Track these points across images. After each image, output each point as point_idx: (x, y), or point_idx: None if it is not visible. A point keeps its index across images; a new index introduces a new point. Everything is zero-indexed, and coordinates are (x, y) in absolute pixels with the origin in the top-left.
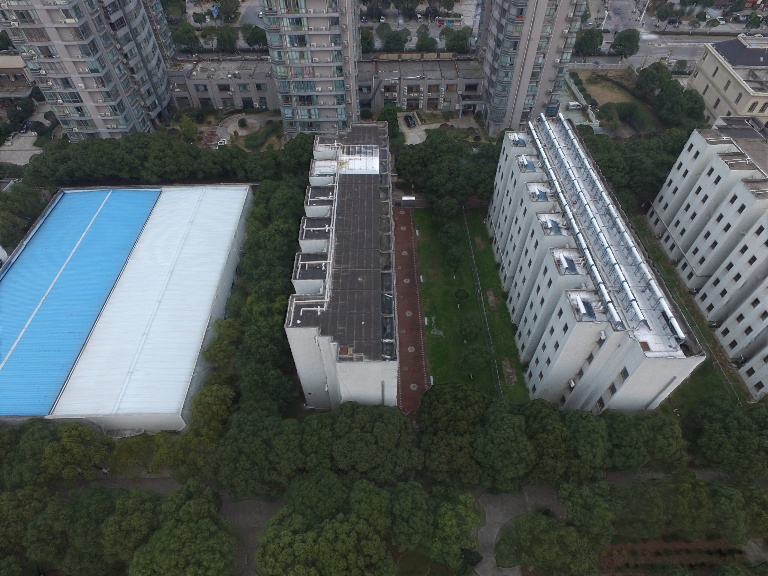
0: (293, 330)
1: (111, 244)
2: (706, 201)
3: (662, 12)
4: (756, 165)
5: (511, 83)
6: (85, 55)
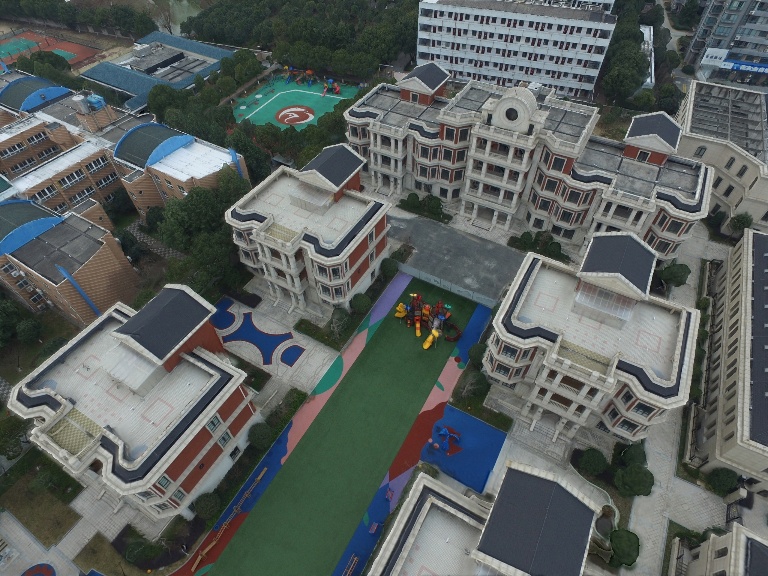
0: None
1: None
2: None
3: None
4: (555, 5)
5: None
6: None
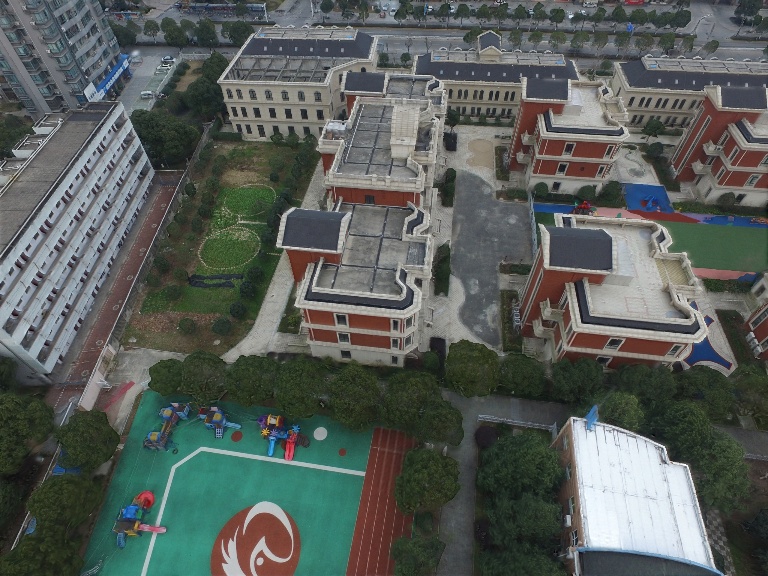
0: None
1: None
2: None
3: (322, 4)
4: None
5: (14, 73)
6: None
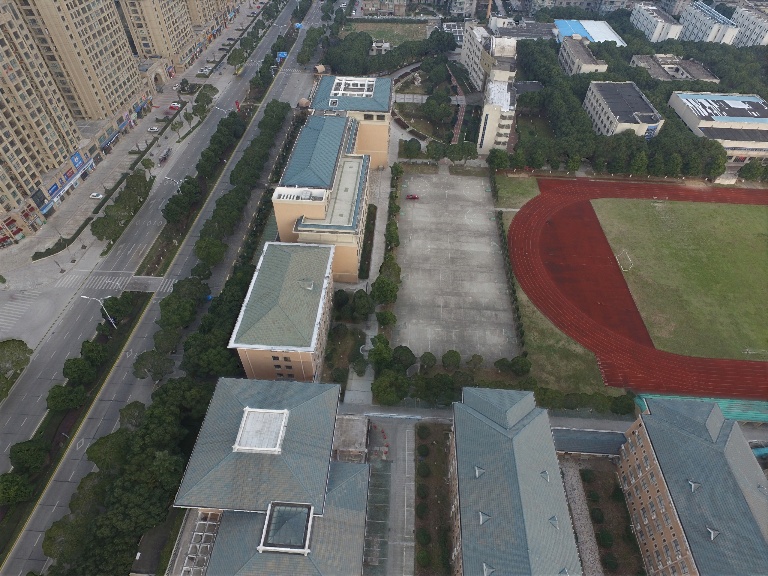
0: (660, 23)
1: None
2: (740, 23)
3: None
4: None
5: (677, 2)
6: None
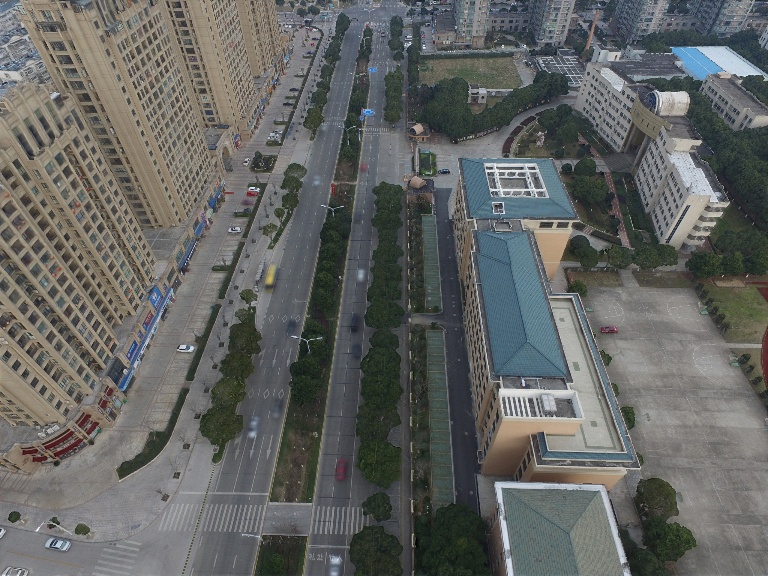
0: None
1: (701, 57)
2: None
3: None
4: None
5: None
6: (667, 4)
